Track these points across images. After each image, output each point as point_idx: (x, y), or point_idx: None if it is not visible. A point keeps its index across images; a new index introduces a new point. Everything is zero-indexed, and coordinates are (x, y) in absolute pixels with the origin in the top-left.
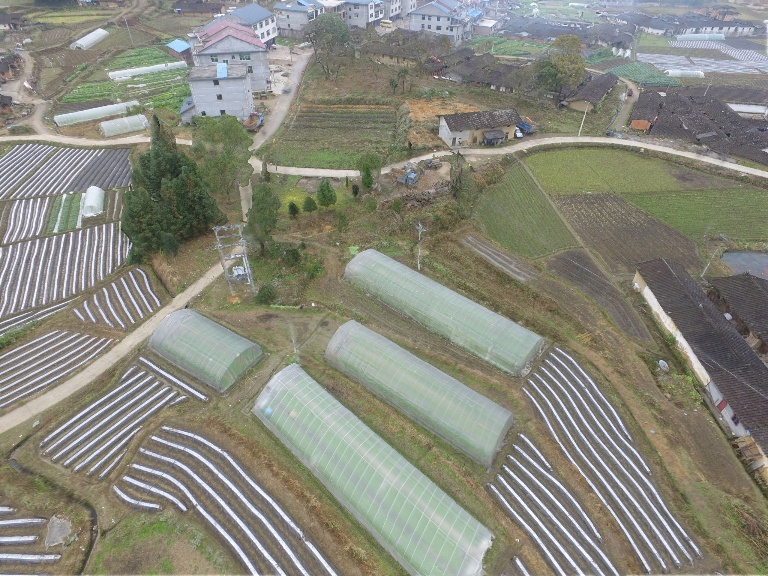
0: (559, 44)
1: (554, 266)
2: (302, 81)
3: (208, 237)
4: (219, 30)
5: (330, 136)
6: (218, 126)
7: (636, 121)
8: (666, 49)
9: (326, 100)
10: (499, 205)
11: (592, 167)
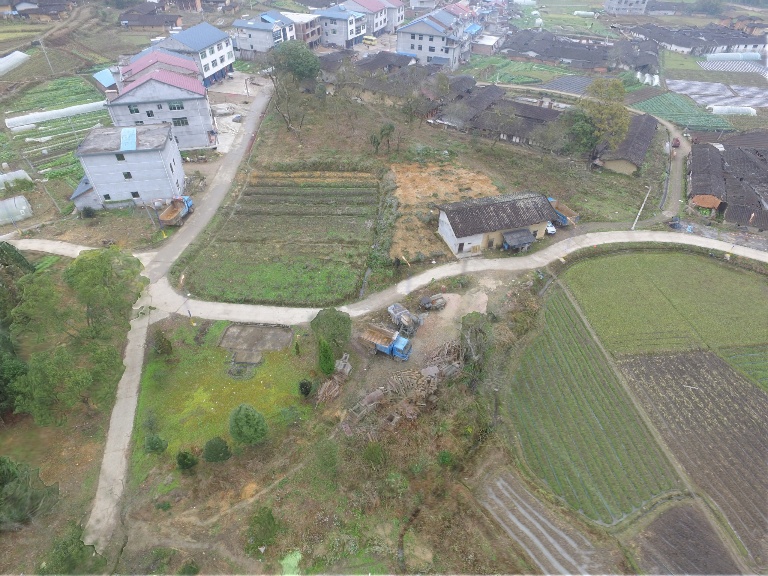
0: (595, 91)
1: (654, 556)
2: (259, 129)
3: (18, 536)
4: (145, 66)
5: (285, 231)
6: (56, 299)
7: (700, 196)
8: (698, 73)
9: (285, 165)
10: (538, 382)
11: (663, 291)
